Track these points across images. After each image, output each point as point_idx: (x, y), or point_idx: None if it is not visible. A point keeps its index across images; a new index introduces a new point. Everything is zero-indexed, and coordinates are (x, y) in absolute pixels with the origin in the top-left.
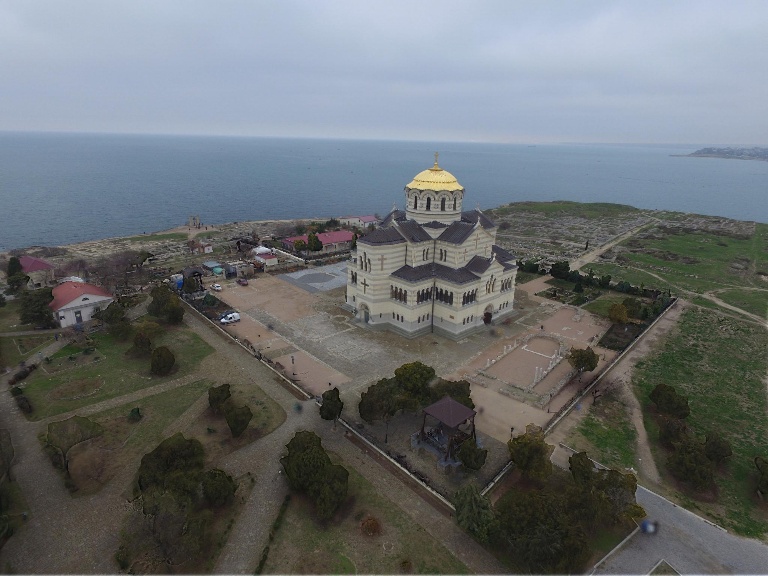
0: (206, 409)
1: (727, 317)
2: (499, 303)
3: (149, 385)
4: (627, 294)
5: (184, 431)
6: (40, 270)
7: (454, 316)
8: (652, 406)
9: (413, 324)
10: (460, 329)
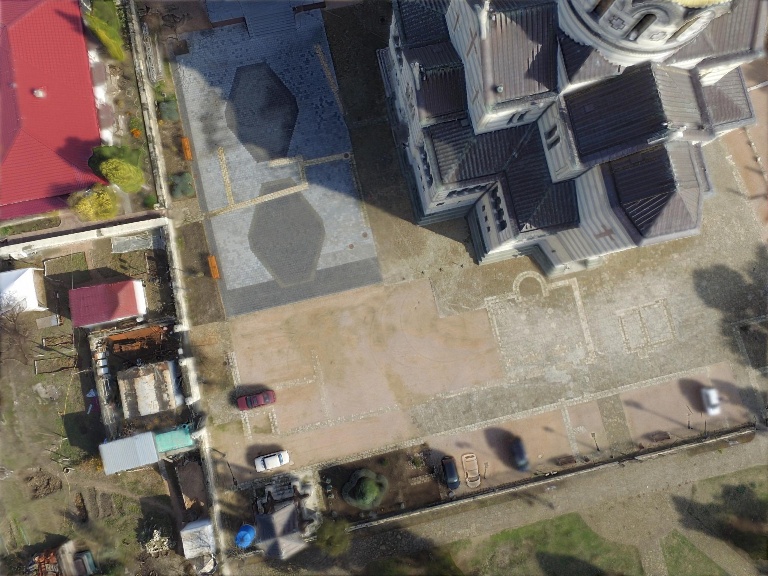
0: (737, 553)
1: None
2: None
3: None
4: None
5: None
6: None
7: None
8: None
9: None
10: None
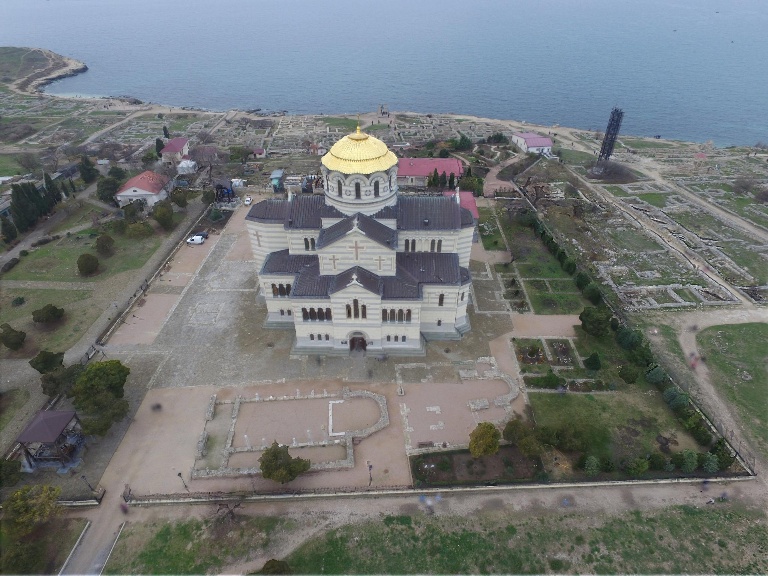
0: None
1: None
2: (384, 333)
3: (67, 280)
4: (669, 413)
5: (16, 327)
6: (168, 152)
7: None
8: None
9: (273, 314)
10: (306, 343)
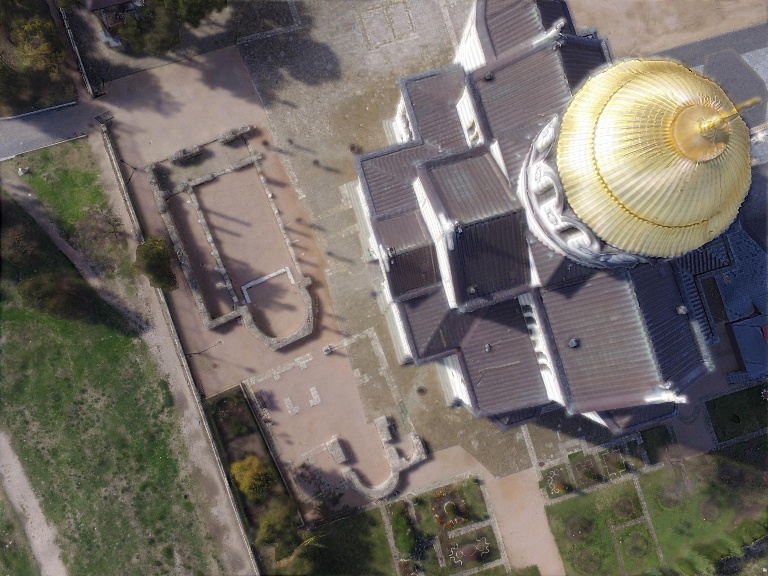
0: None
1: None
2: None
3: None
4: None
5: None
6: None
7: None
8: (88, 305)
9: None
10: None
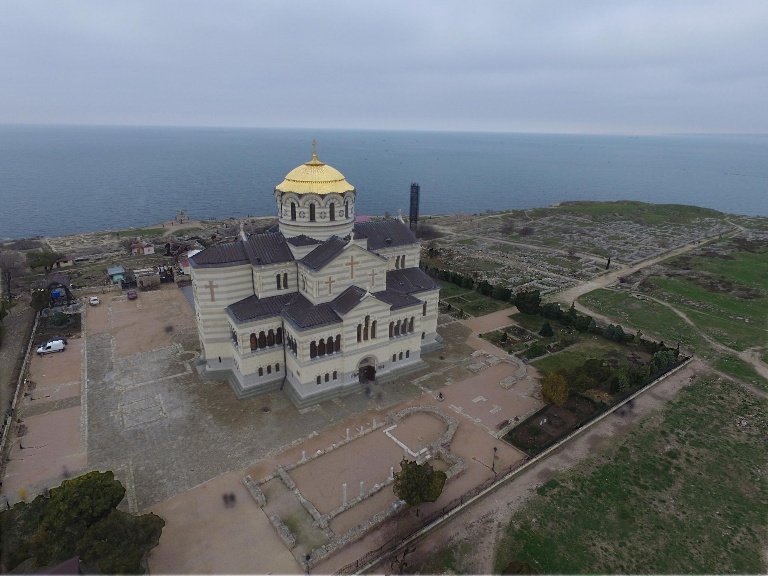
0: None
1: (761, 399)
2: (390, 353)
3: None
4: (617, 344)
5: None
6: None
7: (299, 372)
8: None
9: (249, 378)
10: (311, 390)
